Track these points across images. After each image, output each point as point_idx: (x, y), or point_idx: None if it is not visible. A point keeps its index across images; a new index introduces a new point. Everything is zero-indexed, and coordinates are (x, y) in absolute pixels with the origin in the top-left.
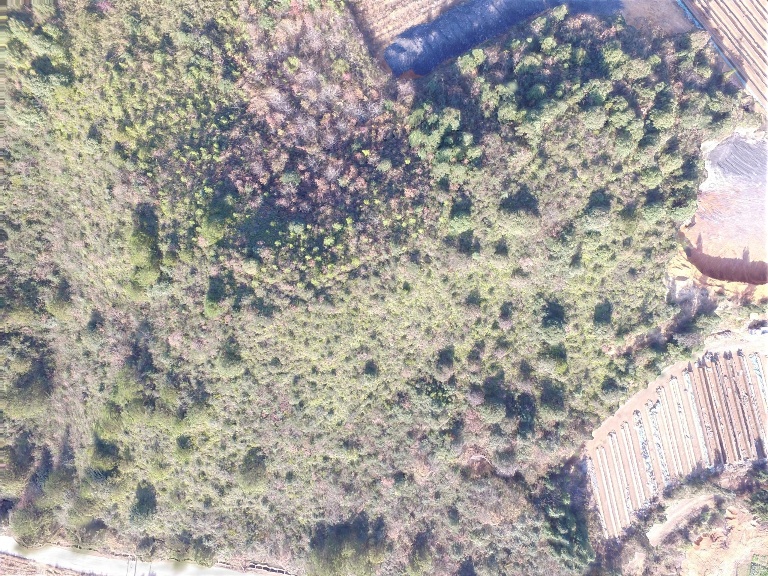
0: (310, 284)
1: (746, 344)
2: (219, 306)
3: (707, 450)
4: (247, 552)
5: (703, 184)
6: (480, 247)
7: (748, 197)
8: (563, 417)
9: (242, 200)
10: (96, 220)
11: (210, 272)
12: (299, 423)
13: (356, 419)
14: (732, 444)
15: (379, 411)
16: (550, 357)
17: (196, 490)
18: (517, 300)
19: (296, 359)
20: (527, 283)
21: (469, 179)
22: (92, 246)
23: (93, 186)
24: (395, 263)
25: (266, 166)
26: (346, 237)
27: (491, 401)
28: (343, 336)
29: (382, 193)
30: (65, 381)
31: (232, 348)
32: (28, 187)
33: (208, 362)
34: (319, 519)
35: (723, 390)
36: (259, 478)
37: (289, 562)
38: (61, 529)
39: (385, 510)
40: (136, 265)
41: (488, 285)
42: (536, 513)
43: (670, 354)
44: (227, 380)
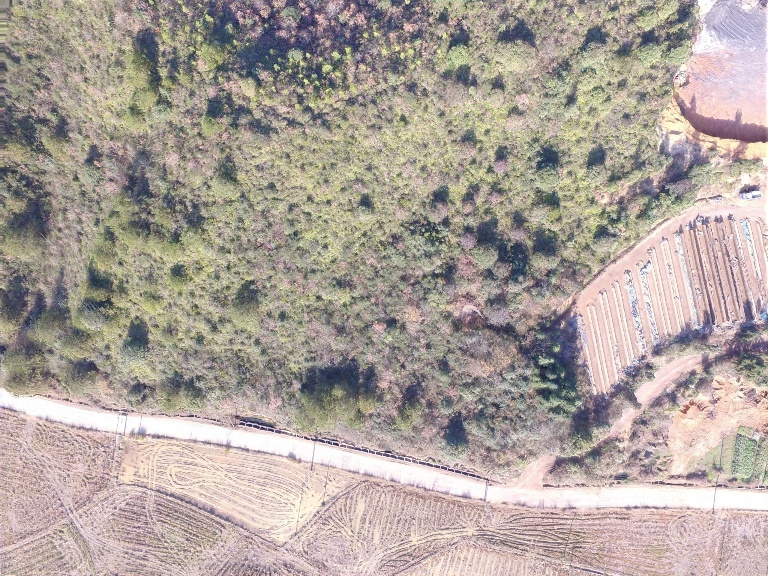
0: (308, 107)
1: (737, 209)
2: (217, 122)
3: (696, 311)
4: (238, 397)
5: (698, 46)
6: (477, 84)
7: (742, 60)
8: (555, 262)
9: (242, 30)
10: (96, 52)
11: (209, 95)
12: (293, 254)
13: (350, 258)
14: (721, 305)
15: (373, 252)
16: (543, 206)
17: (189, 326)
18: (512, 145)
19: (292, 186)
20: (522, 124)
21: (468, 12)
22: (92, 80)
23: (94, 21)
24: (392, 91)
25: (267, 2)
26: (345, 67)
27: (484, 243)
28: (339, 164)
29: (381, 29)
30: (61, 223)
31: (228, 167)
32: (30, 19)
33: (204, 184)
34: (310, 364)
35: (713, 252)
36: (252, 311)
37: (279, 410)
38: (52, 380)
39: (376, 360)
40: (135, 86)
41: (484, 126)
42: (526, 361)
43: (662, 204)
44: (223, 202)
